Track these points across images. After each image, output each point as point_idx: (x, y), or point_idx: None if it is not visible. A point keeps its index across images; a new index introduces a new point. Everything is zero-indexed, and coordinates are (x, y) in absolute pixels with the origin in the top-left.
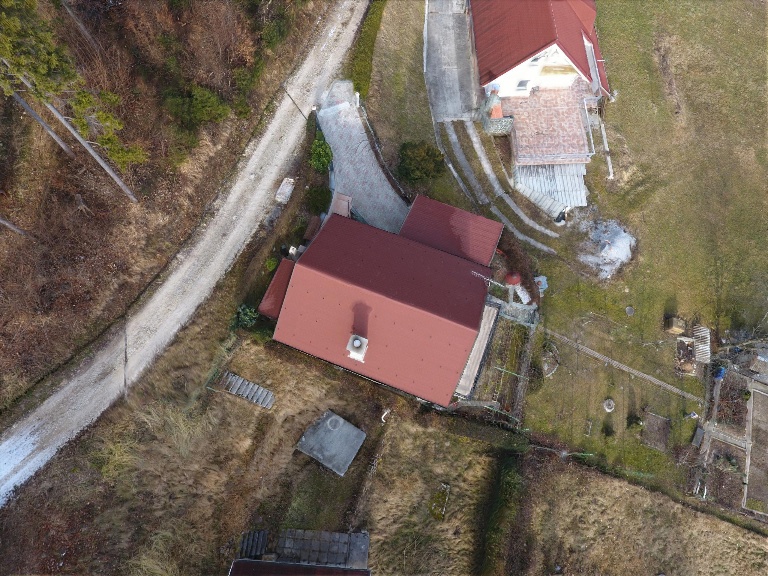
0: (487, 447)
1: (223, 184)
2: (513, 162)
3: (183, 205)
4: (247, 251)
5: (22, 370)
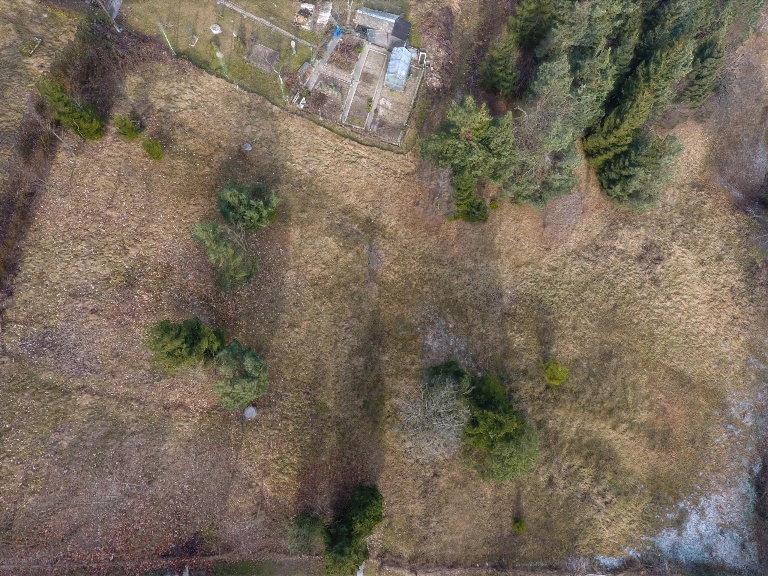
0: None
1: None
2: None
3: None
4: None
5: None
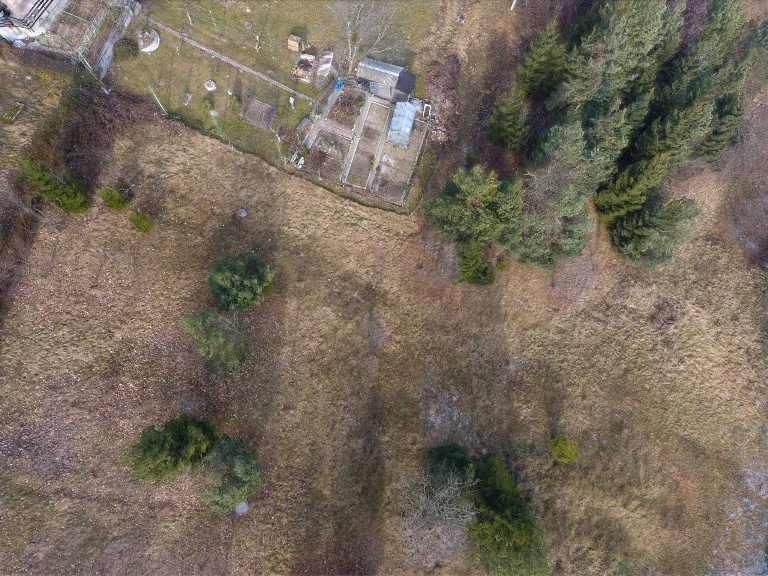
0: None
1: None
2: None
3: None
4: None
5: None
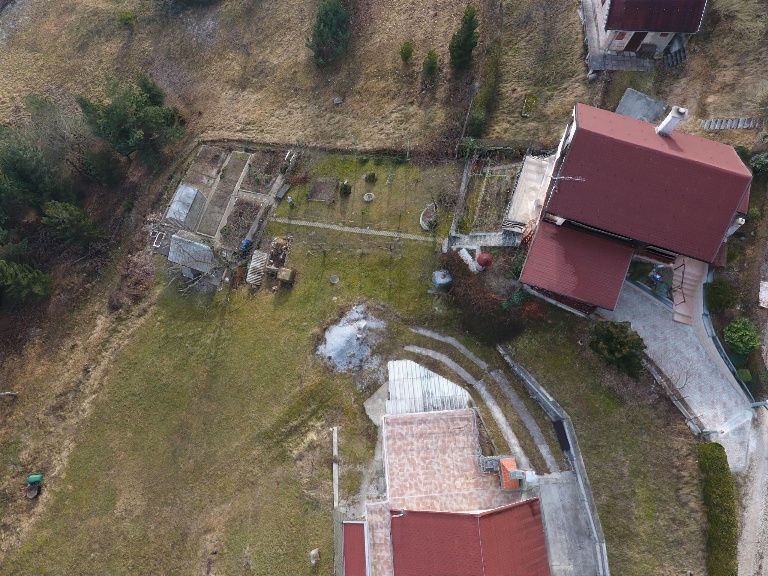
0: None
1: None
2: None
3: None
4: None
5: None
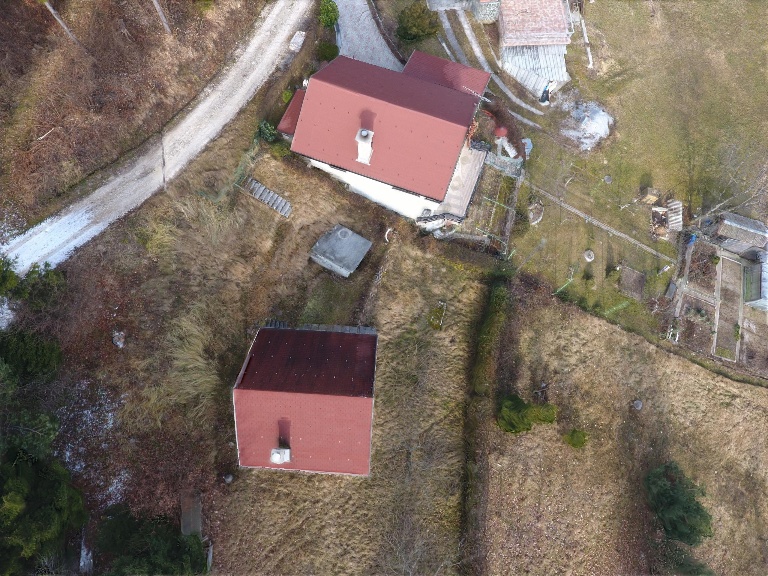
0: (479, 276)
1: (242, 38)
2: (501, 44)
3: (209, 47)
4: (266, 86)
5: (77, 161)
